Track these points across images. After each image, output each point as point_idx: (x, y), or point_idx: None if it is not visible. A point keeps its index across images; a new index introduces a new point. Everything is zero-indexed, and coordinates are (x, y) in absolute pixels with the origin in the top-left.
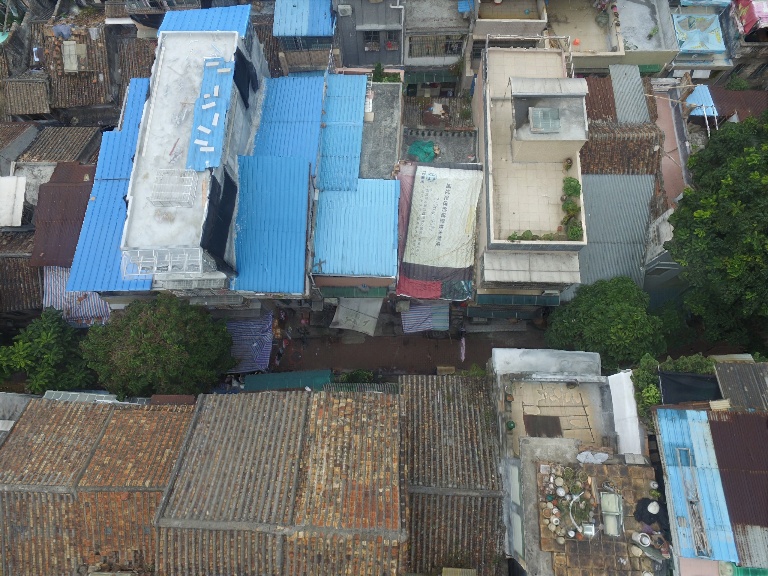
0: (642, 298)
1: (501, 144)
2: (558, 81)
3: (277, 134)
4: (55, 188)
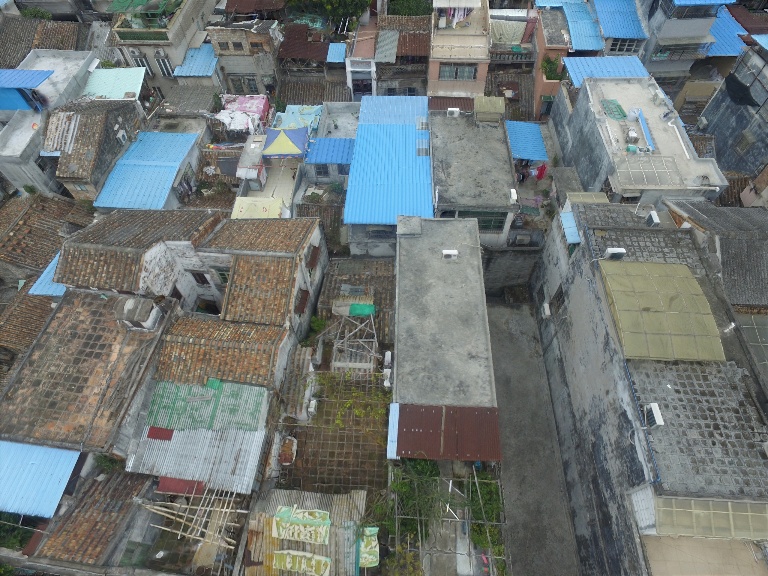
0: (394, 3)
1: (476, 18)
2: (451, 3)
3: (623, 5)
4: (759, 24)
